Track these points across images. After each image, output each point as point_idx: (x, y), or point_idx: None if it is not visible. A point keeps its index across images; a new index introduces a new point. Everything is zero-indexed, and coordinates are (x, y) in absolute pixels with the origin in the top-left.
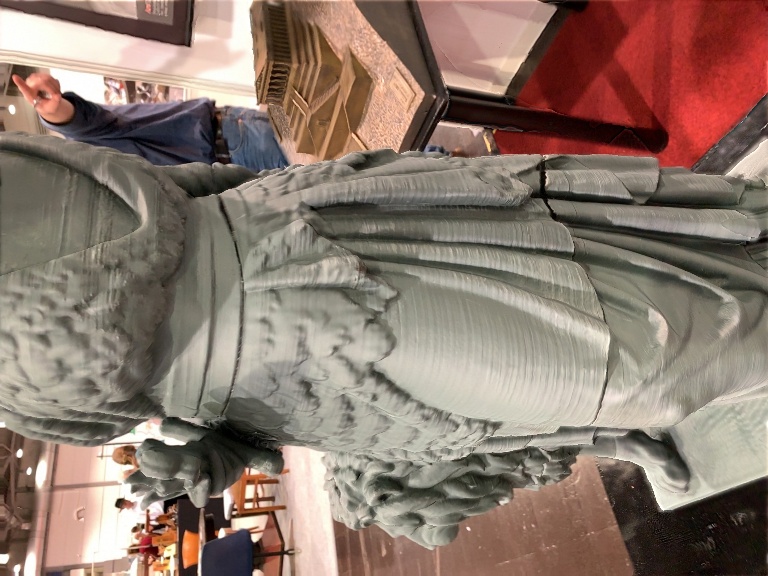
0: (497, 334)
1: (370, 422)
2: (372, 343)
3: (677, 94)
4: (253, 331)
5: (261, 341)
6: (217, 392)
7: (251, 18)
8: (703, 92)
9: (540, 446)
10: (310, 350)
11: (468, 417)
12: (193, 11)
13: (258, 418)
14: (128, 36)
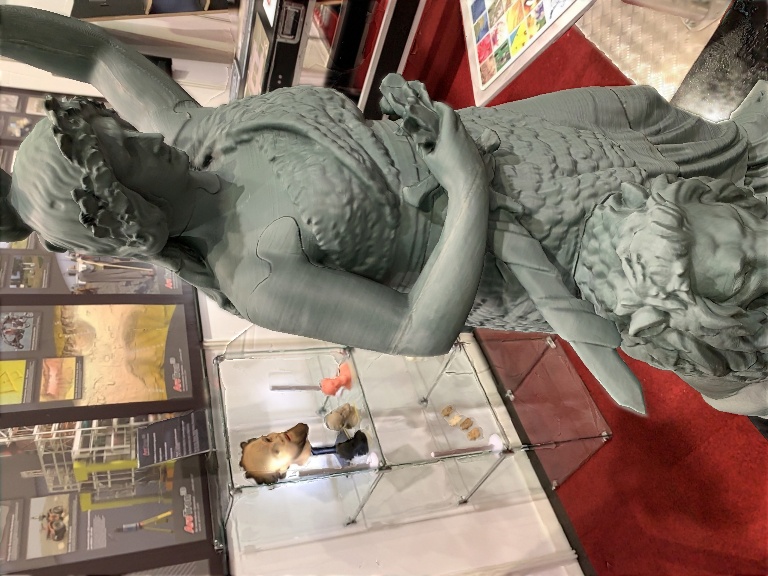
0: None
1: None
2: None
3: (747, 550)
4: None
5: None
6: None
7: None
8: (749, 520)
9: None
10: None
11: (567, 120)
12: None
13: None
14: None
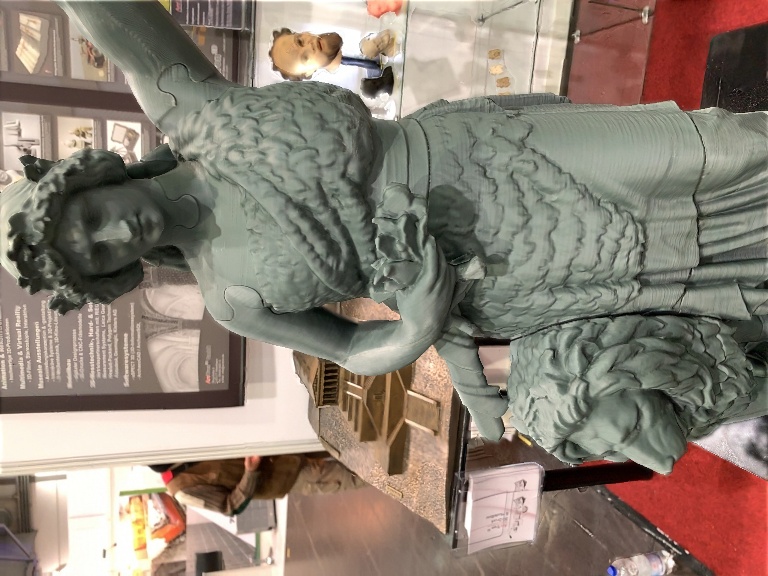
0: (598, 112)
1: (541, 210)
2: (517, 124)
3: None
4: (433, 132)
5: (441, 134)
6: (419, 186)
7: (295, 359)
8: None
9: (701, 313)
10: (476, 136)
11: (614, 193)
12: (245, 373)
13: (454, 214)
14: (190, 410)
